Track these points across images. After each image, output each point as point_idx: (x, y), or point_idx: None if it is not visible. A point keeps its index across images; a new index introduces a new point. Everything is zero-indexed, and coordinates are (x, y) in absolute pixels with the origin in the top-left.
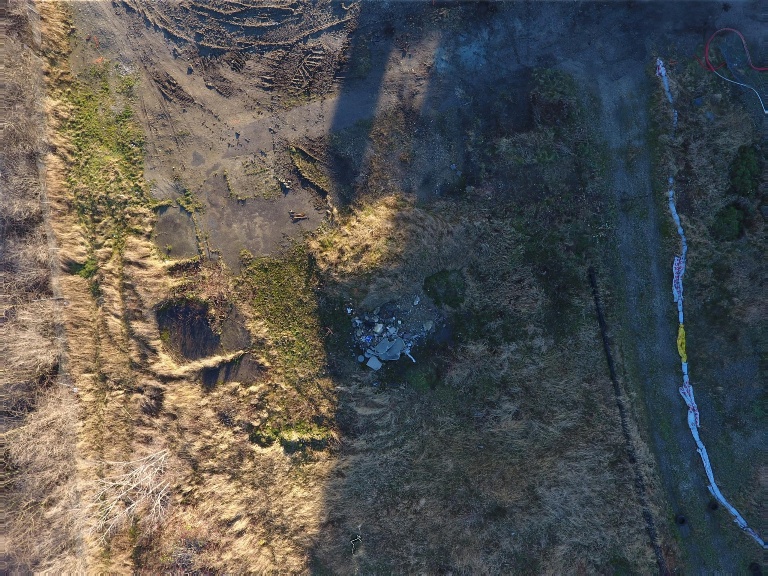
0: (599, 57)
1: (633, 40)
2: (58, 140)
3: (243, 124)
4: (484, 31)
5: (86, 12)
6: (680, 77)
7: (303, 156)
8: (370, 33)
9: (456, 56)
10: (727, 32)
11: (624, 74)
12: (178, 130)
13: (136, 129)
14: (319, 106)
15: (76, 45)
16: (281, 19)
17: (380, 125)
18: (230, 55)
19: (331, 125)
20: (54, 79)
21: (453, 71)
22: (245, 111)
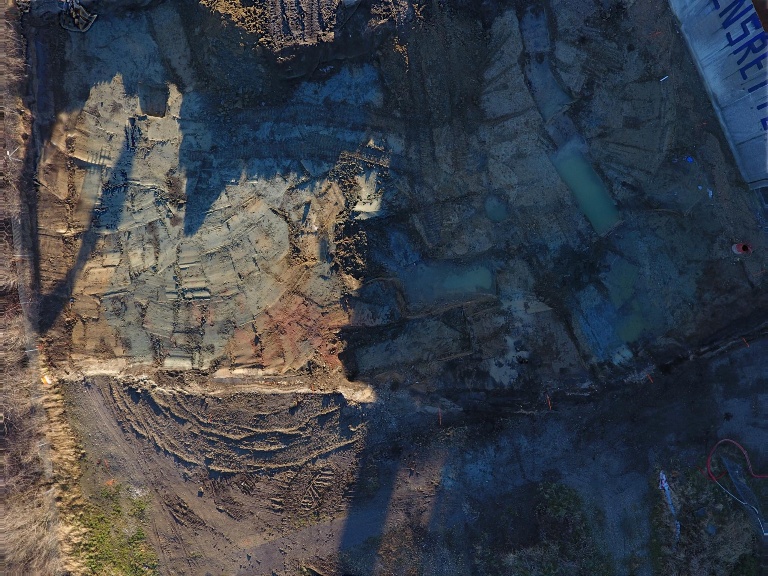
0: (603, 471)
1: (637, 454)
2: (72, 566)
3: (254, 546)
4: (490, 448)
5: (96, 437)
6: (683, 489)
7: (314, 575)
8: (378, 452)
9: (463, 473)
10: (729, 443)
11: (628, 487)
12: (190, 552)
13: (149, 552)
14: (329, 526)
15: (87, 468)
16: (290, 442)
17: (389, 542)
18: (240, 478)
19: (341, 543)
20: (66, 503)
21: (460, 488)
22: (256, 533)
